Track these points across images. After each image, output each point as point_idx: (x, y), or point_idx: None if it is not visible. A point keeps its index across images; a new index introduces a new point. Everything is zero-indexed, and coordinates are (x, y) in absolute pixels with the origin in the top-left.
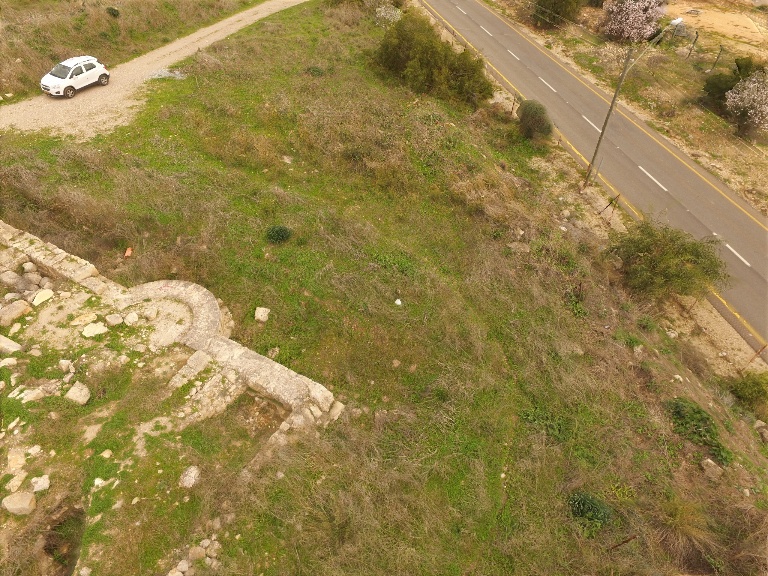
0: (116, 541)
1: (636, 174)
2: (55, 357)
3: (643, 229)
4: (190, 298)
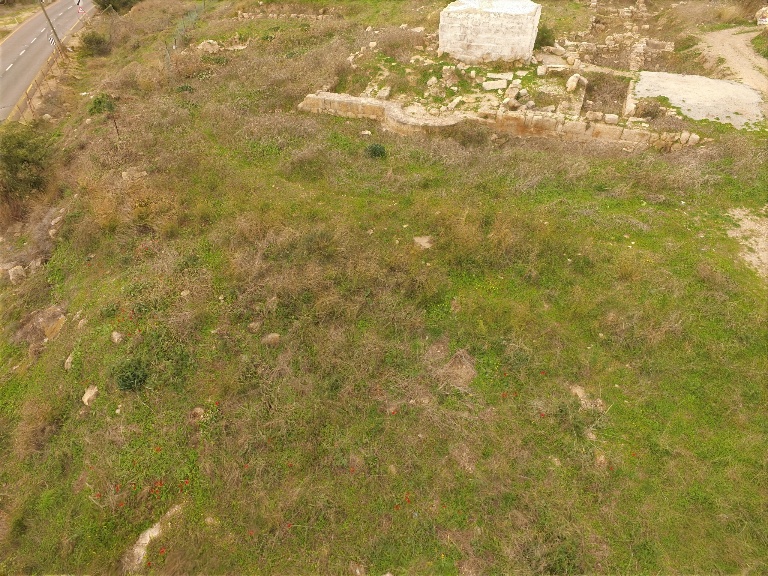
0: (371, 55)
1: None
2: (465, 92)
3: (8, 143)
4: (416, 119)
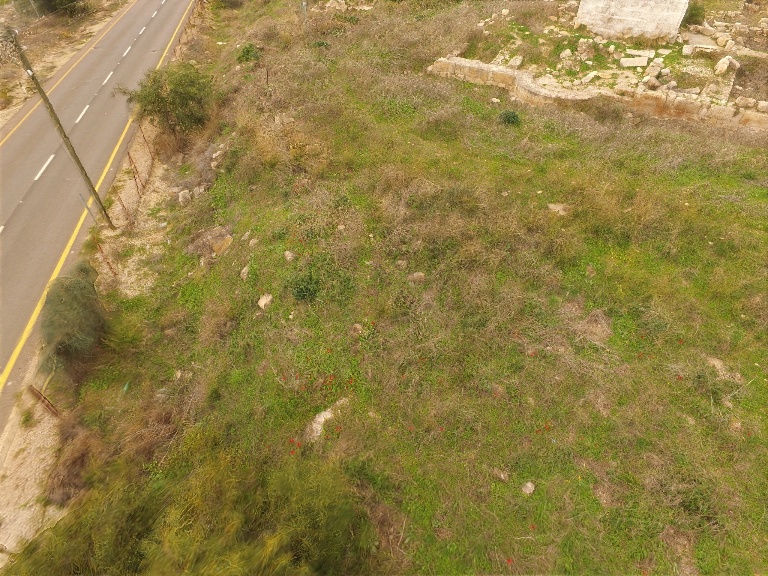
0: None
1: (6, 250)
2: (600, 67)
3: (183, 81)
4: (548, 90)
